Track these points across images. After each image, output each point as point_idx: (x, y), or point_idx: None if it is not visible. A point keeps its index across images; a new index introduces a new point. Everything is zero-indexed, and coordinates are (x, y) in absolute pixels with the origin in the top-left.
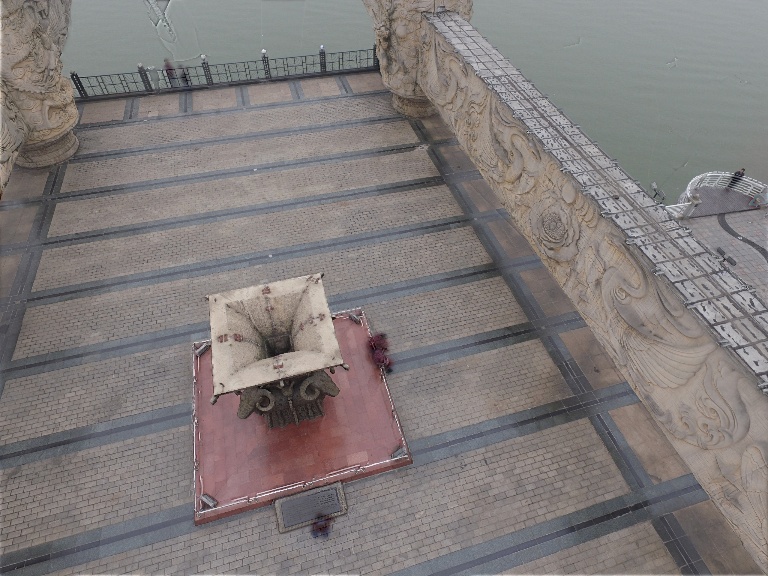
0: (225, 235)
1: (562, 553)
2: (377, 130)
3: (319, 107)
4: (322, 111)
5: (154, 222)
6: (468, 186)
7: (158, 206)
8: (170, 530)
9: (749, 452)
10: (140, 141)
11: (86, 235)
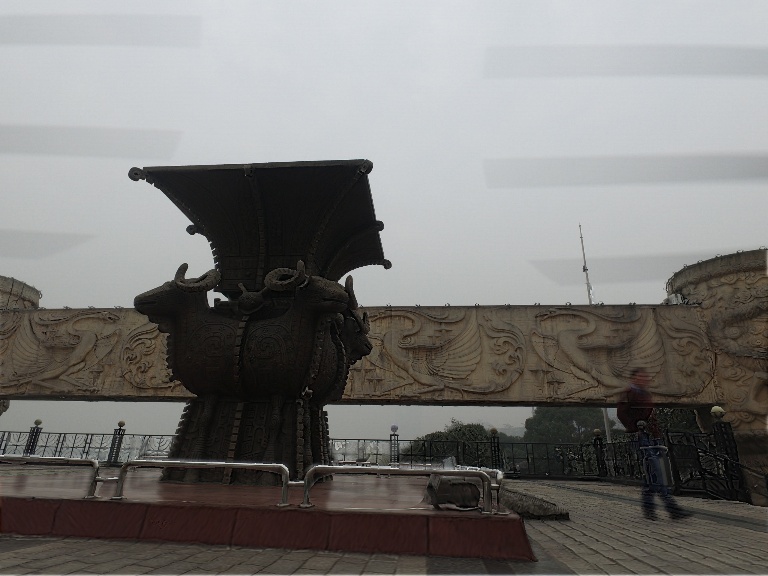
0: None
1: (590, 489)
2: None
3: None
4: None
5: None
6: None
7: None
8: None
9: (534, 341)
10: None
11: None
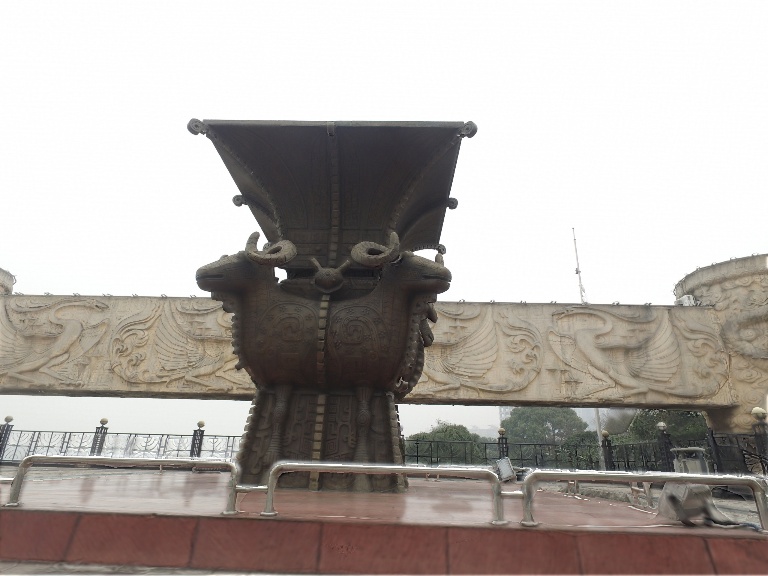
0: None
1: None
2: None
3: None
4: None
5: None
6: None
7: None
8: None
9: (551, 339)
10: None
11: None
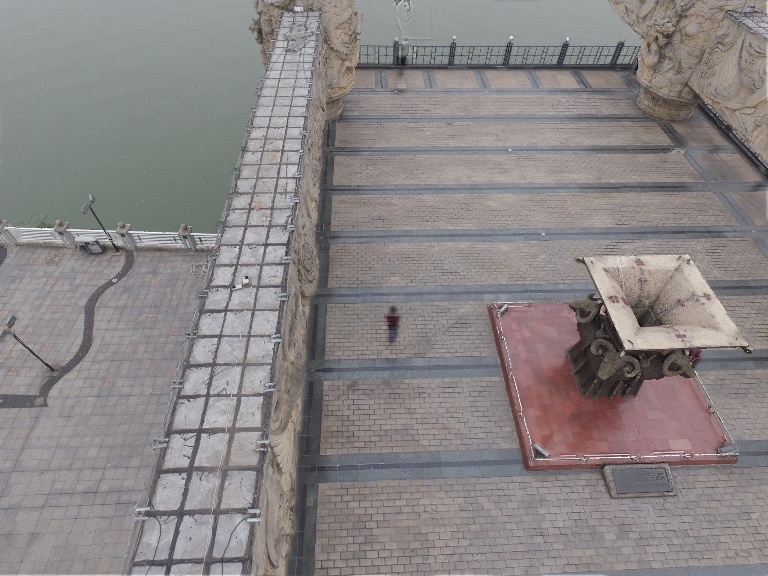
0: (495, 207)
1: None
2: (626, 128)
3: (560, 98)
4: (564, 102)
5: (425, 185)
6: (738, 197)
7: (426, 171)
8: (503, 469)
9: None
10: (396, 110)
11: (367, 188)
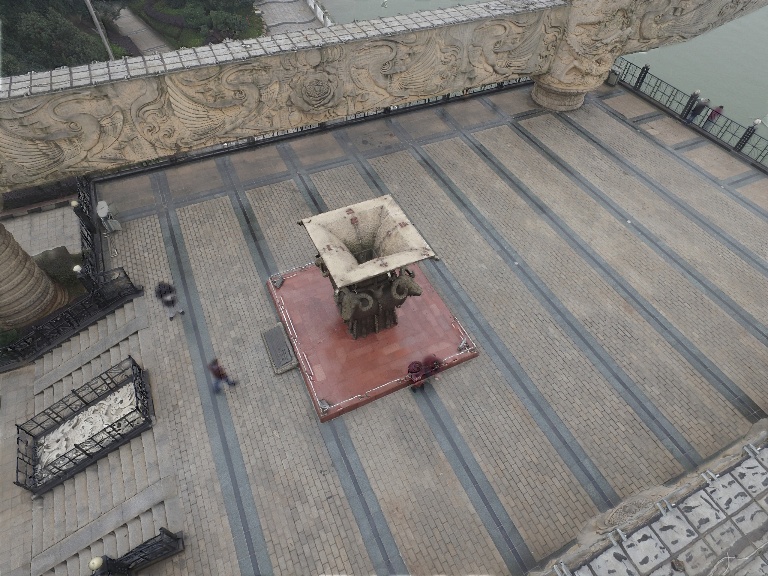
0: (525, 225)
1: None
2: None
3: None
4: None
5: (516, 178)
6: None
7: (535, 174)
8: (263, 271)
9: None
10: (608, 137)
11: (482, 149)
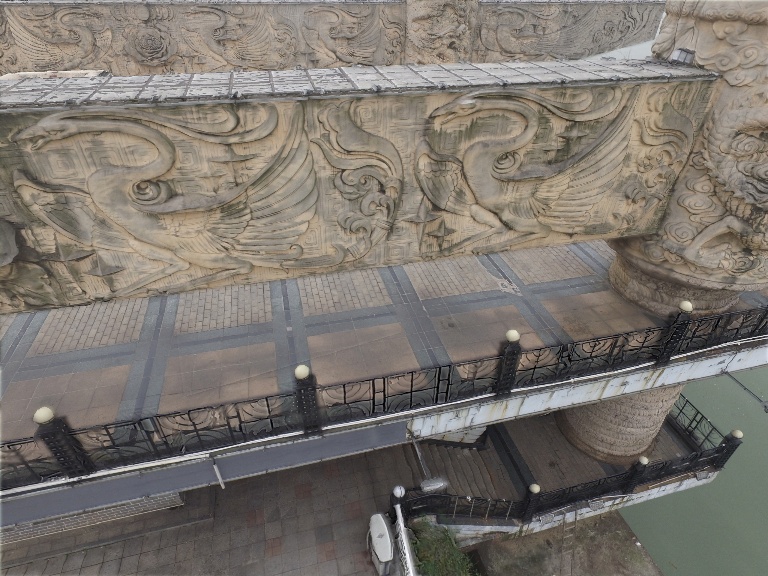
0: None
1: None
2: None
3: None
4: None
5: None
6: (387, 330)
7: None
8: None
9: None
10: None
11: None
